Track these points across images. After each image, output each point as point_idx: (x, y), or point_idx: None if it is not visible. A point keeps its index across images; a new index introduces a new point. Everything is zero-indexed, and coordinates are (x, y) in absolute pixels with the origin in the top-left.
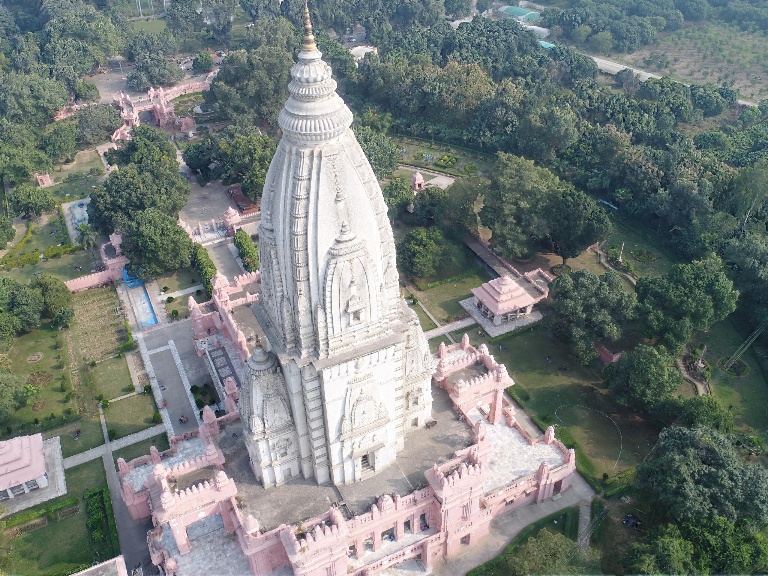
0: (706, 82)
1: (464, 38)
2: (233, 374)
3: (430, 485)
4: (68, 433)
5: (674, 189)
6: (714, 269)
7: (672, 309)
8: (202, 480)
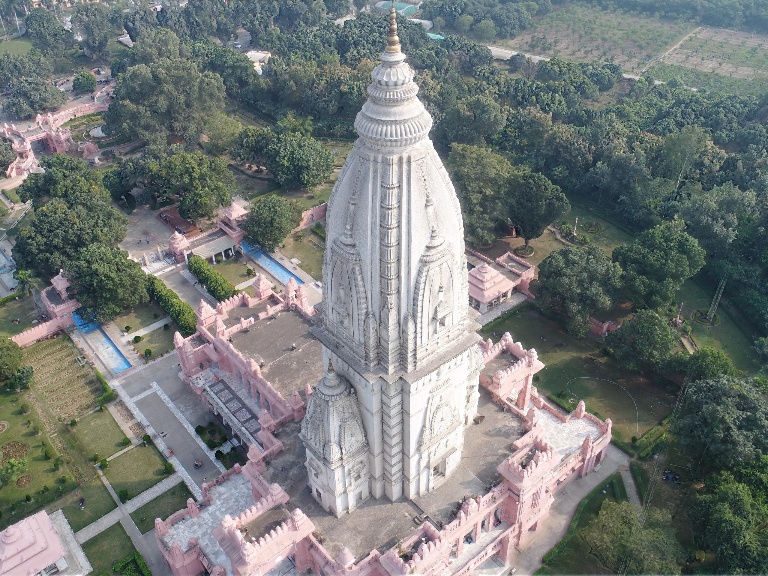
0: (589, 60)
1: (357, 36)
2: (243, 406)
3: (504, 480)
4: (70, 504)
5: (613, 161)
6: (679, 230)
7: (653, 273)
8: (274, 523)
